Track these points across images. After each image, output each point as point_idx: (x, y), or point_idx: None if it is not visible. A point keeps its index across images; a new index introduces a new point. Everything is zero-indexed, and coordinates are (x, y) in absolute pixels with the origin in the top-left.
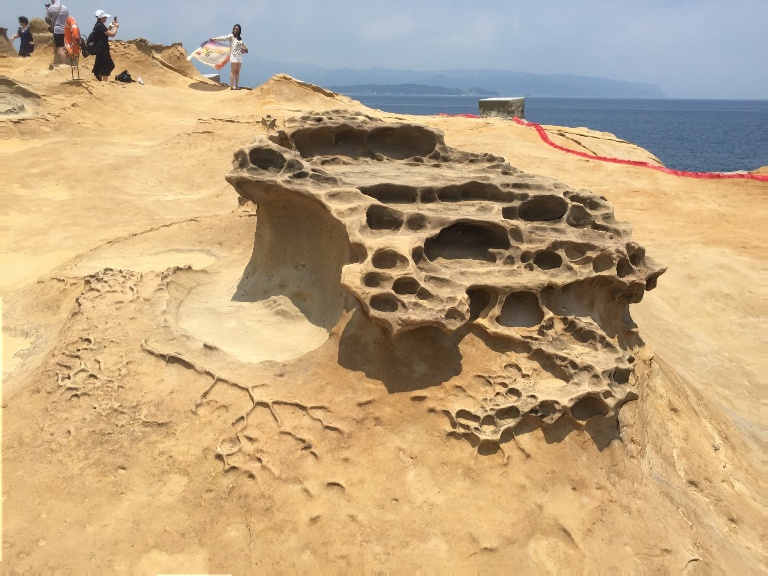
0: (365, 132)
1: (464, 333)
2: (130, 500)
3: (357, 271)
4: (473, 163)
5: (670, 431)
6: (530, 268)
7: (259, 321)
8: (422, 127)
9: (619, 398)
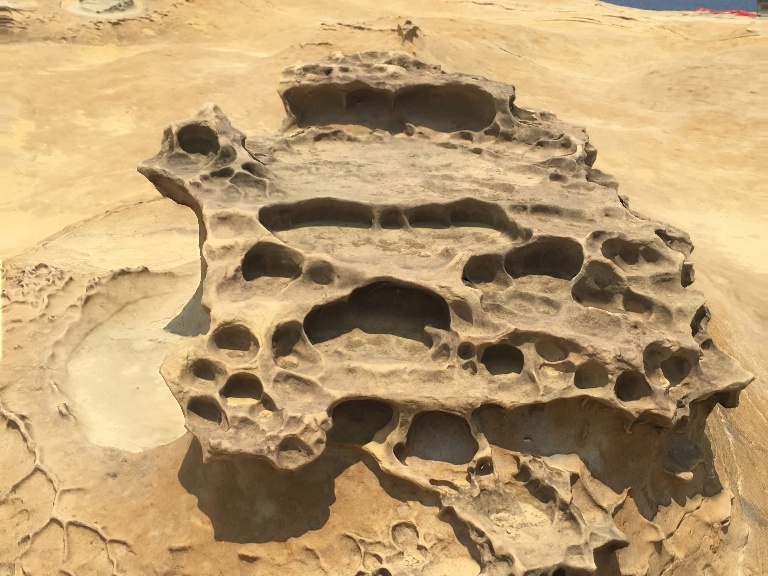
0: (388, 93)
1: (350, 461)
2: None
3: (181, 355)
4: (542, 148)
5: None
6: (473, 369)
7: None
8: (477, 86)
9: None
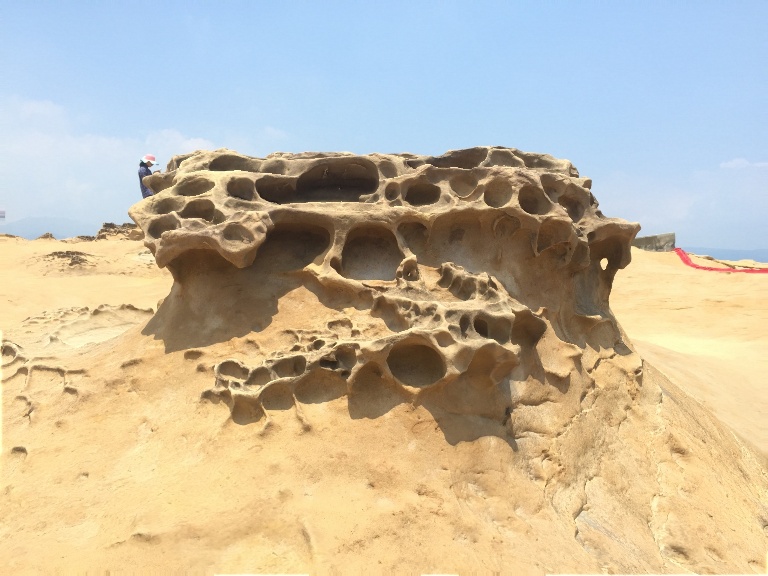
0: None
1: (293, 286)
2: None
3: (148, 198)
4: None
5: (659, 474)
6: None
7: None
8: (410, 155)
9: (463, 344)
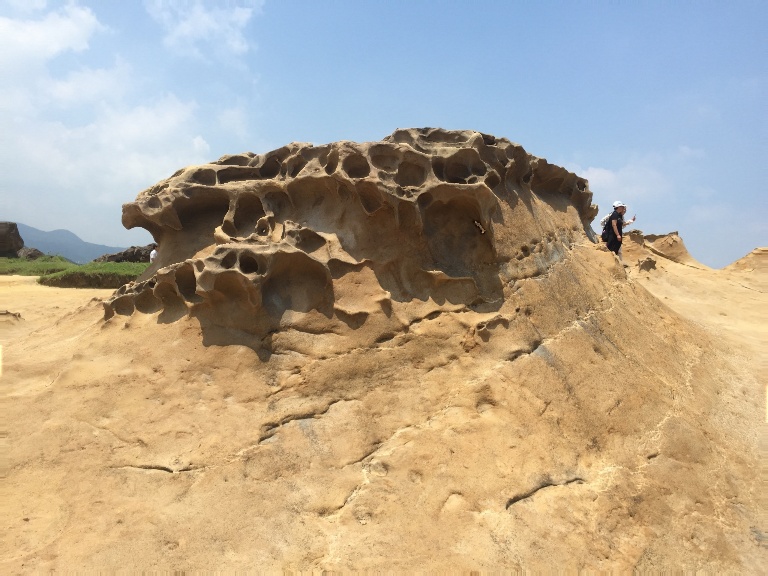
0: None
1: (211, 243)
2: None
3: None
4: None
5: (438, 413)
6: None
7: None
8: None
9: (205, 269)
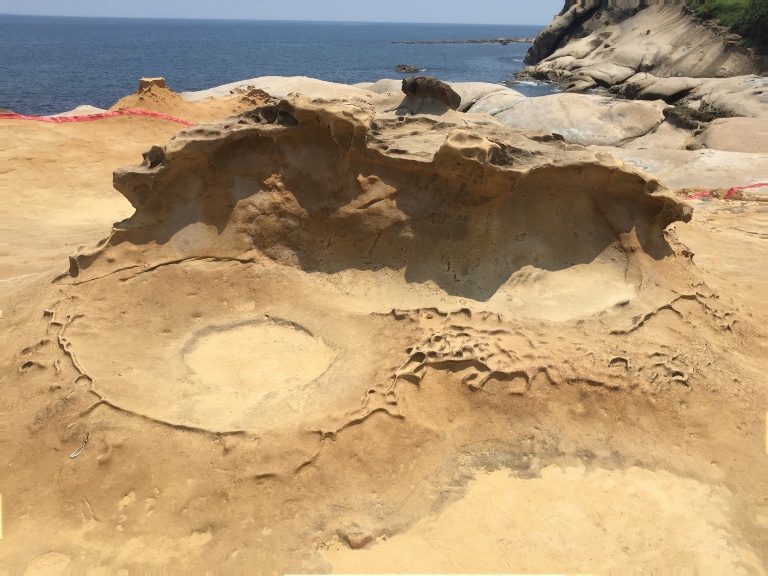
0: None
1: None
2: (762, 374)
3: None
4: (397, 127)
5: None
6: None
7: (543, 291)
8: None
9: None
